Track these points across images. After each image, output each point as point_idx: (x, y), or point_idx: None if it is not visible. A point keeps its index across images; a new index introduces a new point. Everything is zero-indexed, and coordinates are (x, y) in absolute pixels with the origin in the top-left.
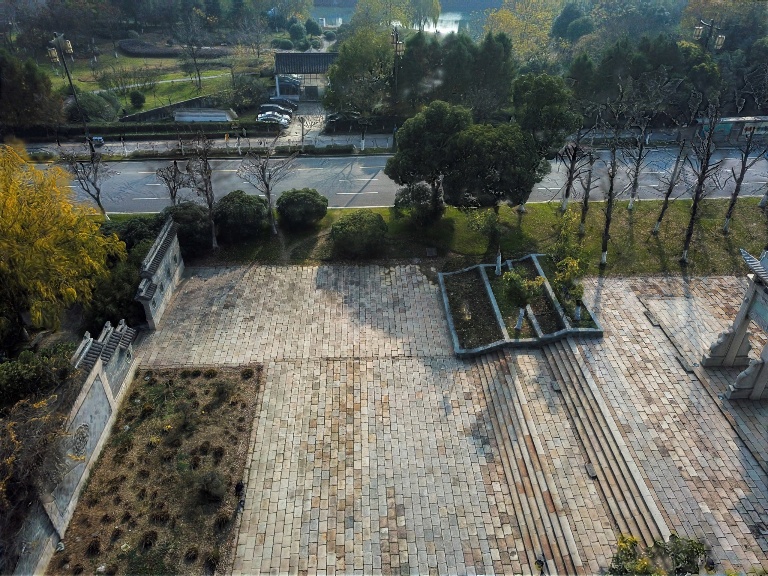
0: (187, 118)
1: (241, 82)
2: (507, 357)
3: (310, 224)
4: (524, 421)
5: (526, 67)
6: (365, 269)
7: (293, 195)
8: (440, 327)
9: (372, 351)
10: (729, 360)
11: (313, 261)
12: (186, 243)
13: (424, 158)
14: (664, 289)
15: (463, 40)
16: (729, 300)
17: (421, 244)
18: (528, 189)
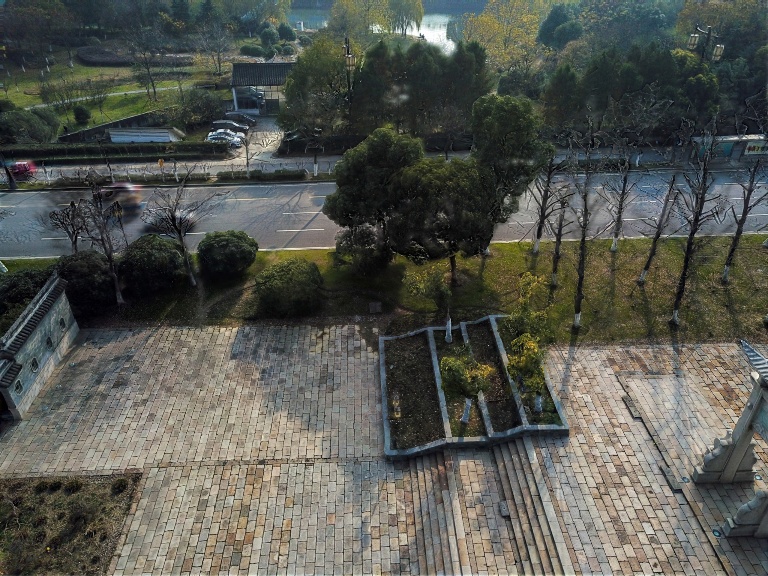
0: (126, 138)
1: (191, 96)
2: (447, 463)
3: (235, 273)
4: (459, 566)
5: (506, 77)
6: (294, 331)
7: (214, 240)
8: (372, 414)
9: (282, 450)
10: (728, 475)
11: (234, 320)
12: (81, 301)
13: (364, 197)
14: (649, 363)
15: (430, 50)
16: (729, 379)
17: (364, 297)
18: (485, 237)
